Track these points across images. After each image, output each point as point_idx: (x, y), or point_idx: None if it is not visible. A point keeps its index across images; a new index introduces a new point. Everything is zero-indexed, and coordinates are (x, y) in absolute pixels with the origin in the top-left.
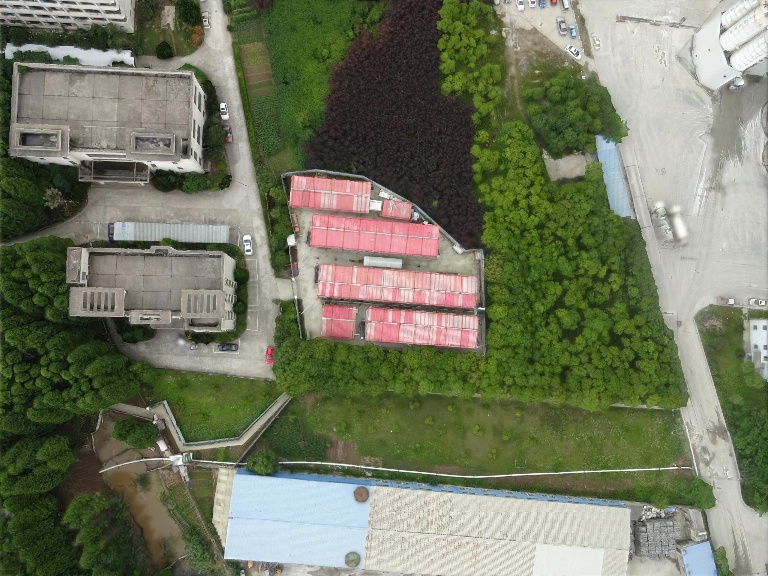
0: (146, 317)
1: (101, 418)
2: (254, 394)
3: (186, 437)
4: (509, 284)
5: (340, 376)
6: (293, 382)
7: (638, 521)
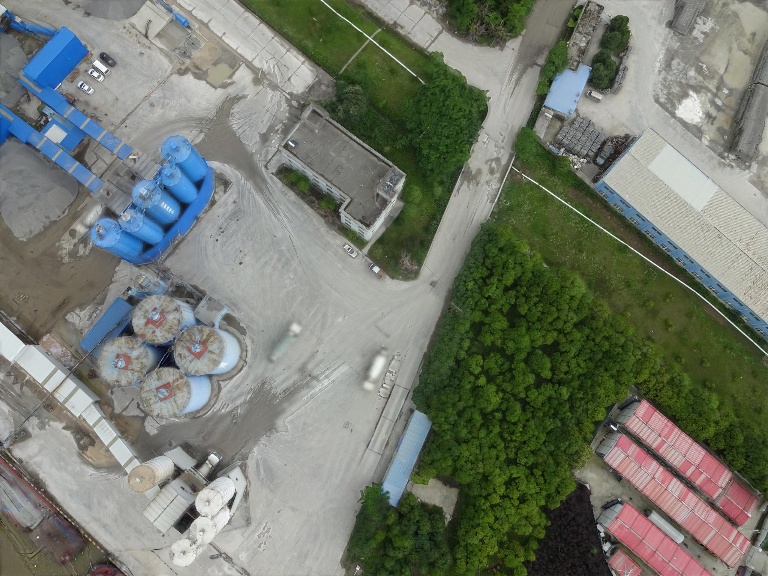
0: None
1: None
2: None
3: None
4: None
5: None
6: None
7: None
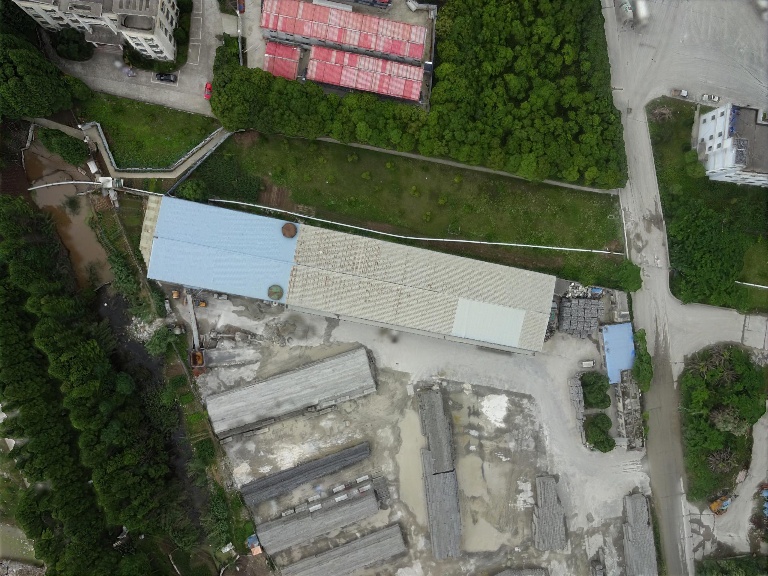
0: (79, 19)
1: (32, 135)
2: (190, 128)
3: (118, 163)
4: (459, 40)
5: (276, 106)
6: (227, 104)
7: (564, 298)
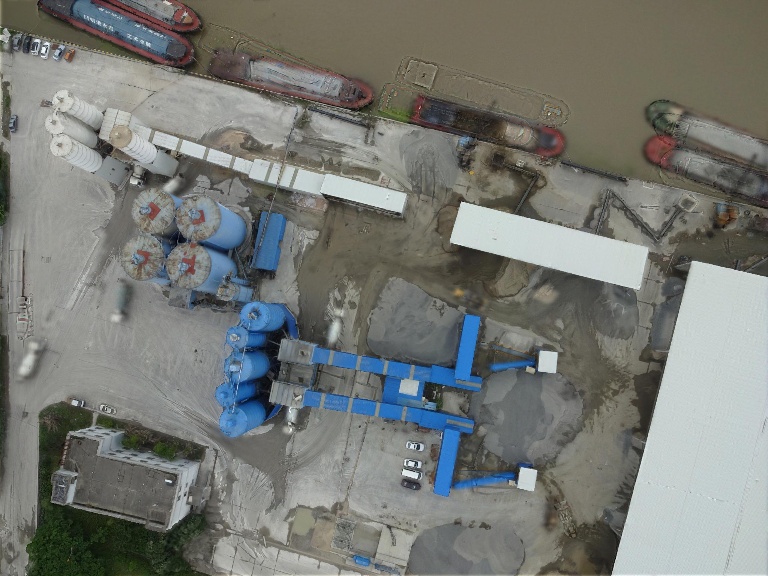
0: None
1: None
2: None
3: None
4: None
5: None
6: None
7: None
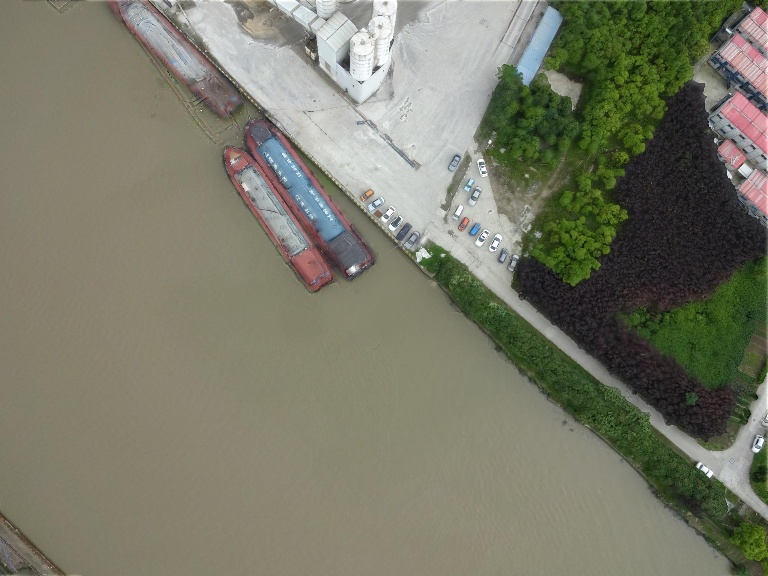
0: None
1: None
2: None
3: None
4: None
5: None
6: None
7: None
